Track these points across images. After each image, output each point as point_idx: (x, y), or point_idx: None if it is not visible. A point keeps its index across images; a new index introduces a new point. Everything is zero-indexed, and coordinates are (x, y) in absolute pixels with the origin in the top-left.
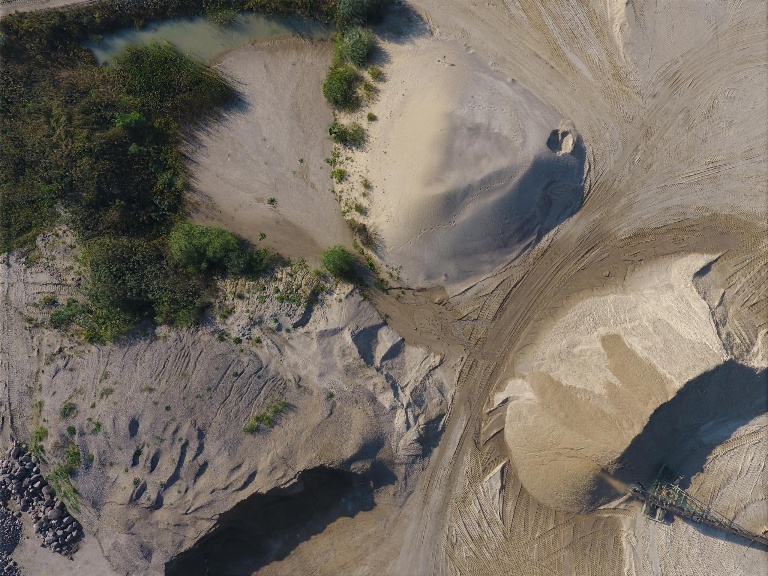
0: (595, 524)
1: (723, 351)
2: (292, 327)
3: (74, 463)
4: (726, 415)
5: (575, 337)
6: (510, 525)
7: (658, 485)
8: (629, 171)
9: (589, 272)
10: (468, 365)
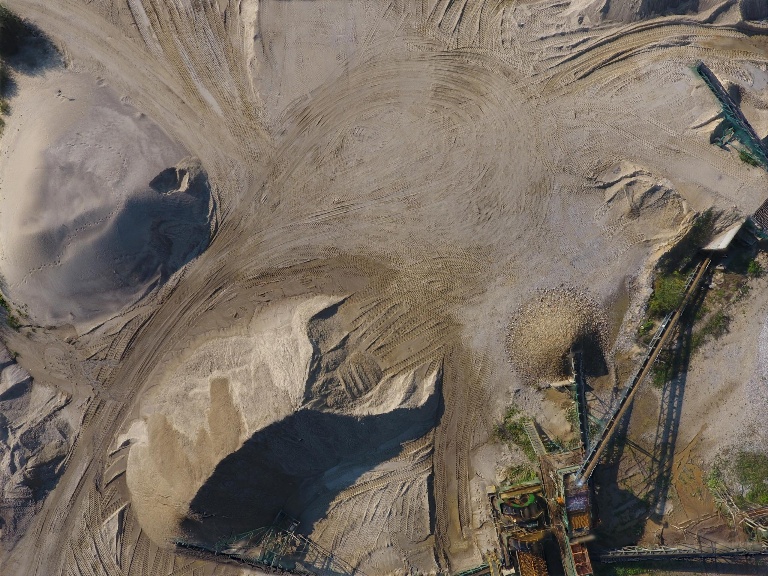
0: (216, 569)
1: (299, 400)
2: None
3: None
4: (351, 460)
5: (193, 379)
6: (128, 570)
7: (271, 532)
8: (255, 210)
9: (217, 312)
10: (95, 406)
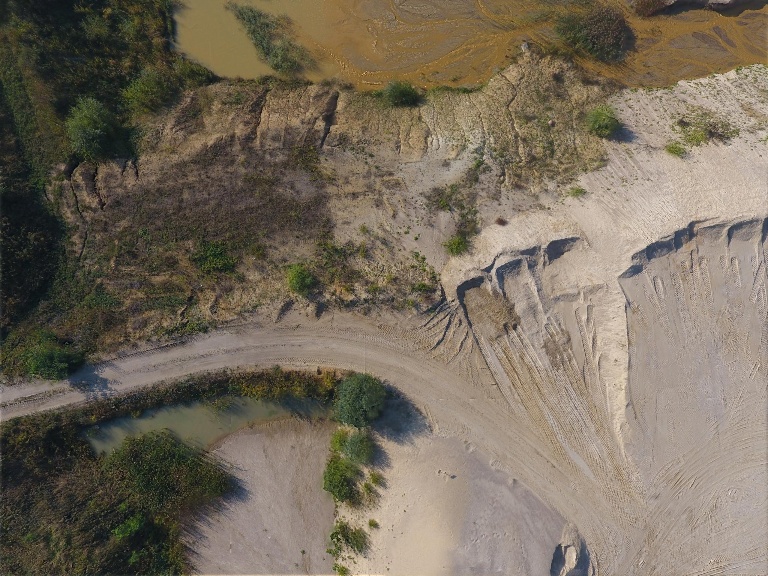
0: None
1: None
2: None
3: None
4: None
5: None
6: None
7: None
8: (633, 574)
9: None
10: None
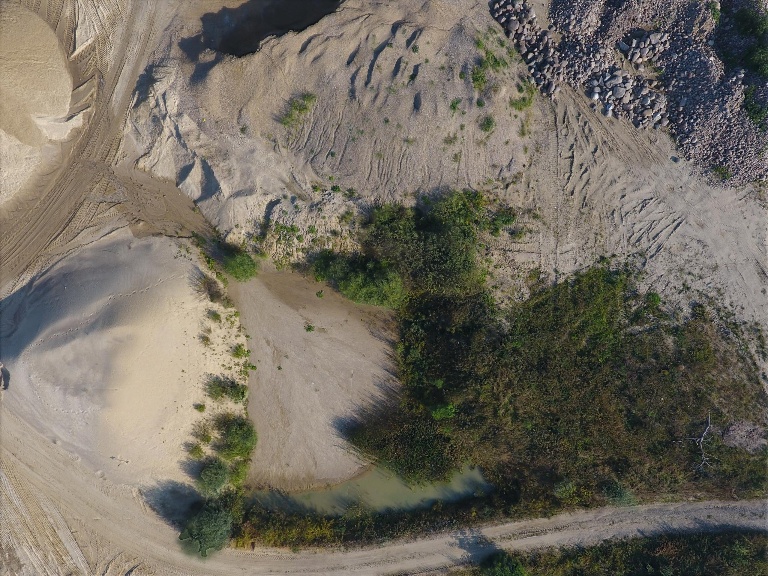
0: None
1: None
2: (281, 200)
3: (479, 71)
4: None
5: None
6: None
7: None
8: None
9: None
10: (110, 157)
